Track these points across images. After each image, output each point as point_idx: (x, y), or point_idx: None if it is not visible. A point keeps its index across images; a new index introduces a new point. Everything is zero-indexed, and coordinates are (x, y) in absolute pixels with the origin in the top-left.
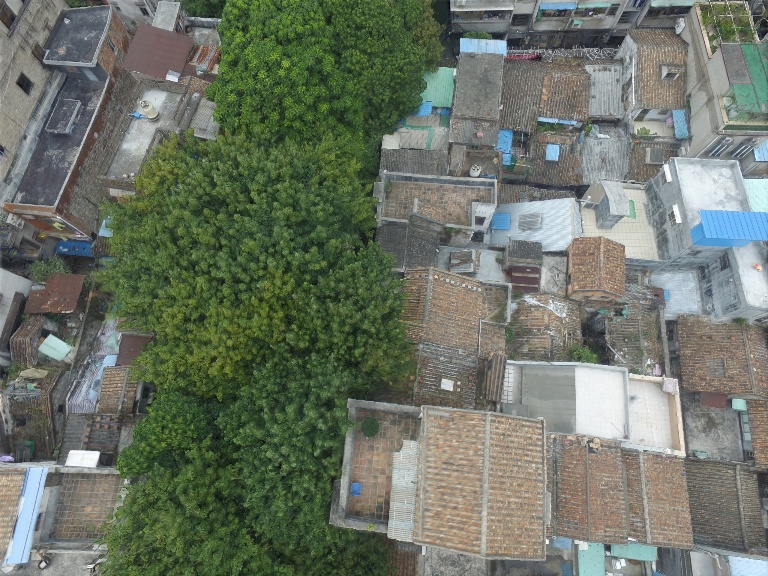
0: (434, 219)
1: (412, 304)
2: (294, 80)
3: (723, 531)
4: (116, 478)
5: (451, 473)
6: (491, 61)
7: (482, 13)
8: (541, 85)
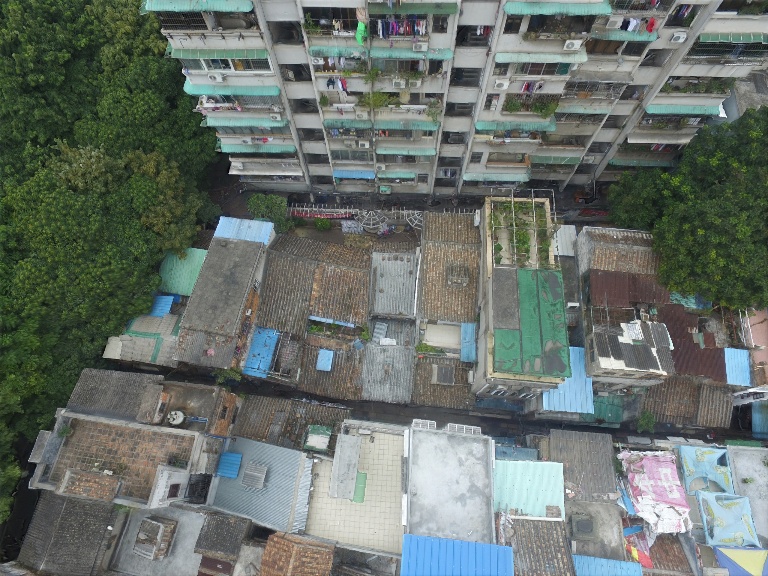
0: (93, 497)
1: None
2: None
3: None
4: None
5: None
6: (245, 252)
7: None
8: (311, 279)
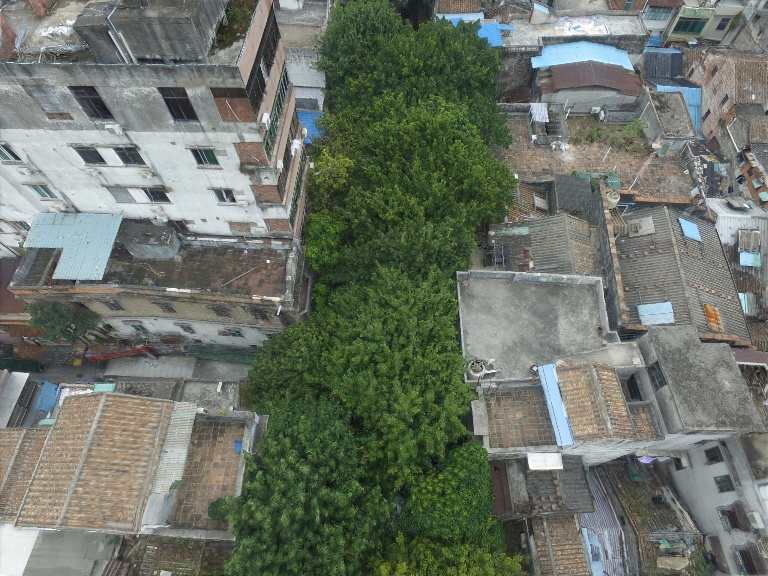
0: None
1: None
2: None
3: None
4: (503, 445)
5: (121, 462)
6: None
7: None
8: None
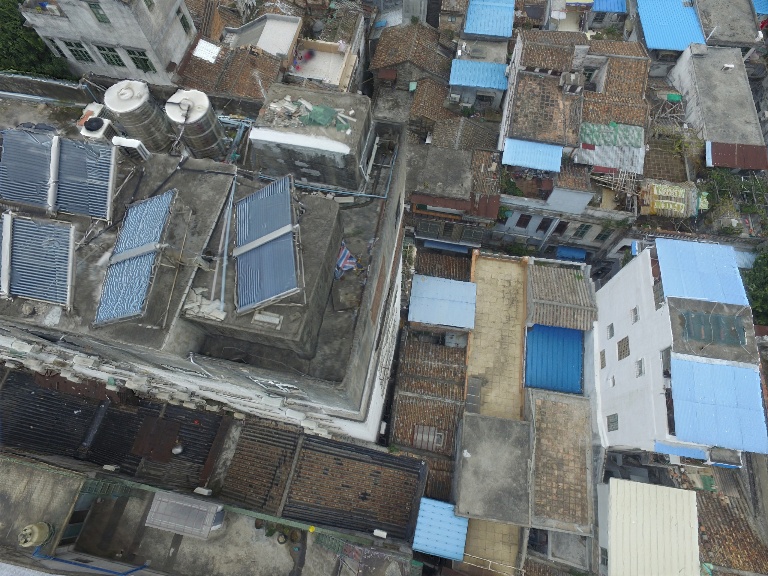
0: None
1: None
2: None
3: None
4: None
5: None
6: None
7: None
8: None
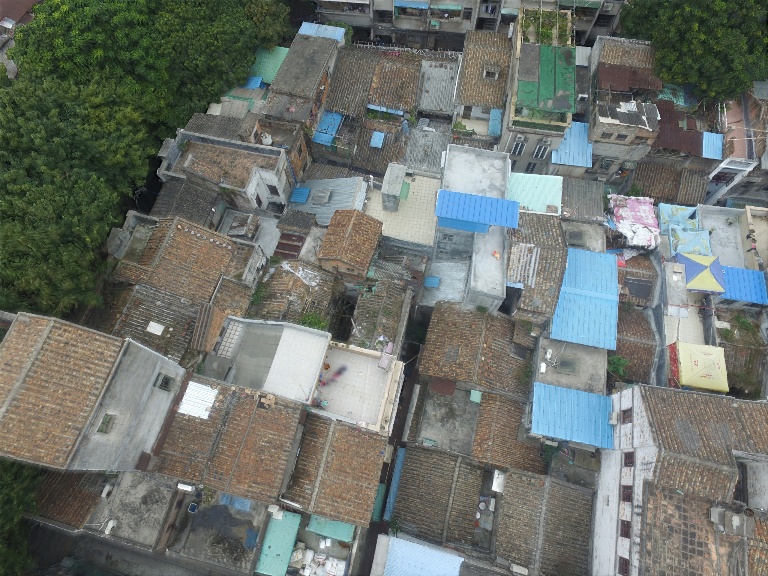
0: (206, 177)
1: (151, 250)
2: (70, 24)
3: (429, 522)
4: None
5: (3, 373)
6: (322, 44)
7: (342, 5)
8: (372, 73)
